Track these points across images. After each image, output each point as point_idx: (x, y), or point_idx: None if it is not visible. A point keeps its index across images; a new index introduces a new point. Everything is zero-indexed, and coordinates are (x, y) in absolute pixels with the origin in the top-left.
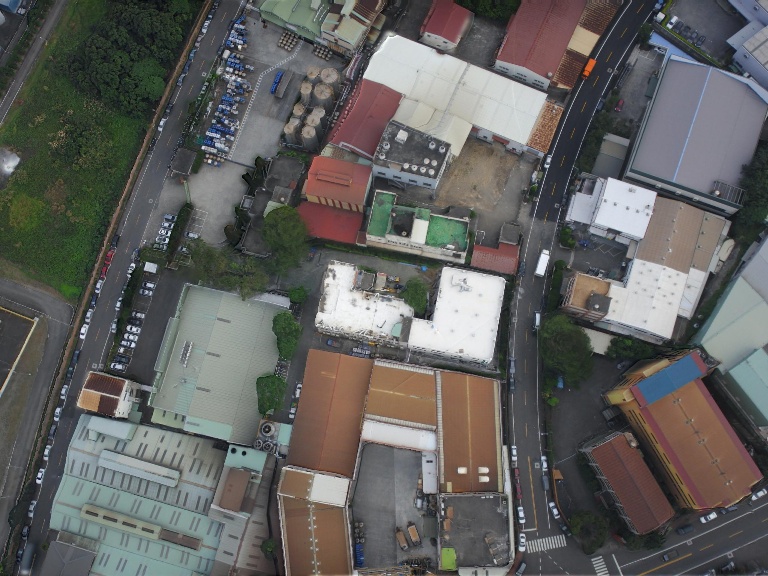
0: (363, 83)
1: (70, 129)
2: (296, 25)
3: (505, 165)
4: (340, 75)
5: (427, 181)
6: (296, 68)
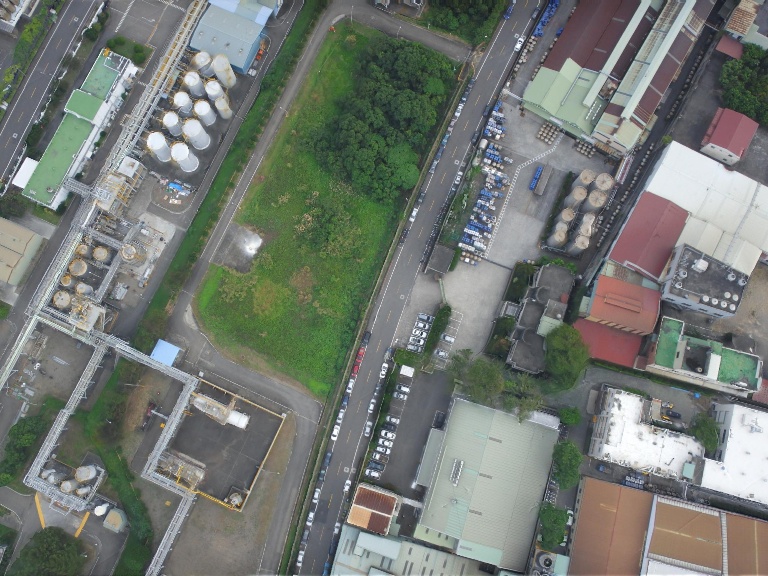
0: (647, 196)
1: (317, 213)
2: (564, 120)
3: None
4: (614, 181)
5: (721, 313)
6: (556, 163)
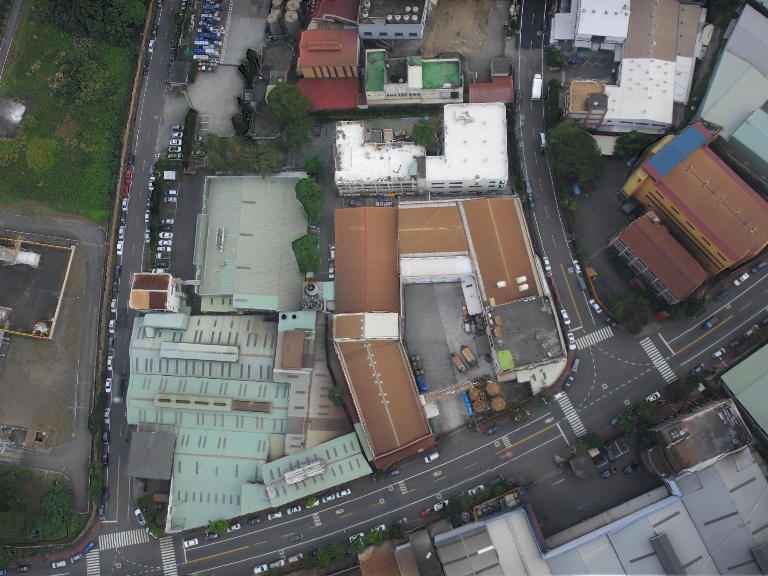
0: None
1: (66, 68)
2: None
3: (482, 7)
4: None
5: (412, 30)
6: None
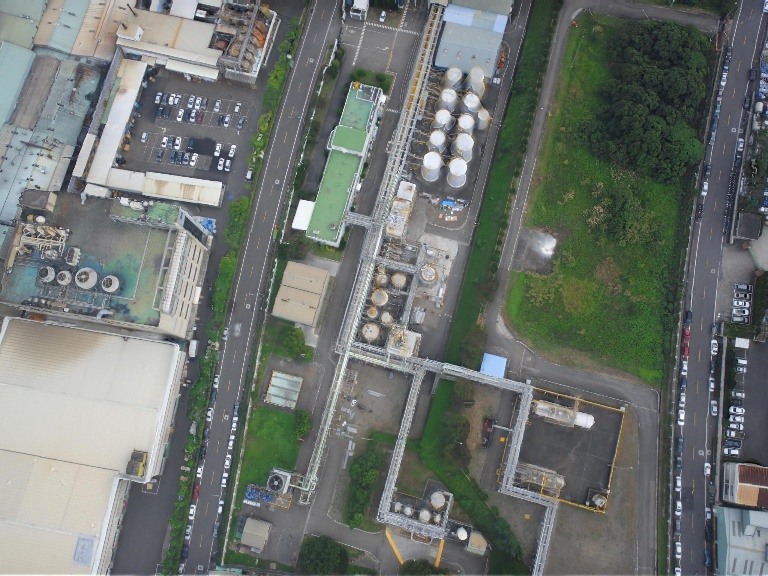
0: None
1: (608, 203)
2: None
3: None
4: None
5: None
6: None
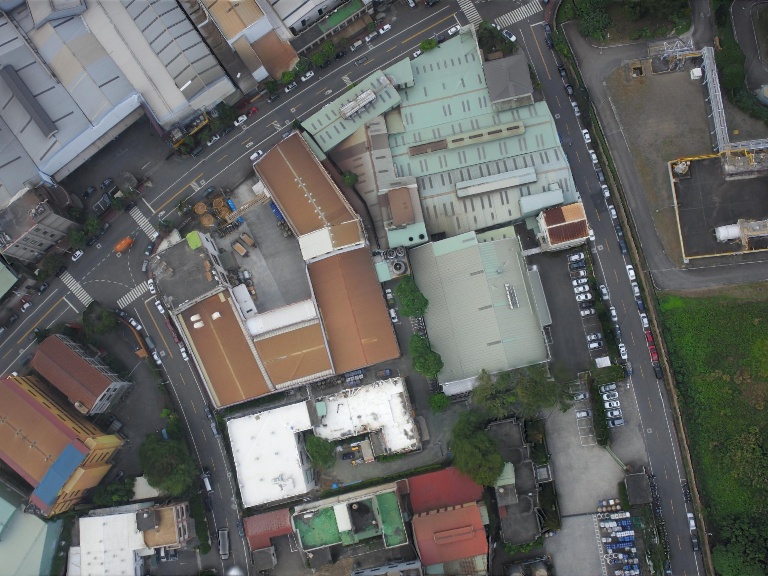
0: None
1: None
2: None
3: None
4: None
5: (359, 575)
6: None
